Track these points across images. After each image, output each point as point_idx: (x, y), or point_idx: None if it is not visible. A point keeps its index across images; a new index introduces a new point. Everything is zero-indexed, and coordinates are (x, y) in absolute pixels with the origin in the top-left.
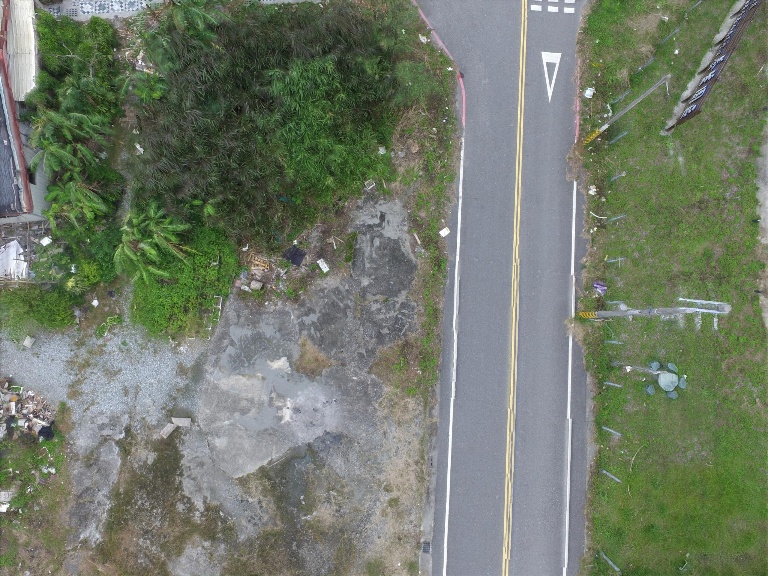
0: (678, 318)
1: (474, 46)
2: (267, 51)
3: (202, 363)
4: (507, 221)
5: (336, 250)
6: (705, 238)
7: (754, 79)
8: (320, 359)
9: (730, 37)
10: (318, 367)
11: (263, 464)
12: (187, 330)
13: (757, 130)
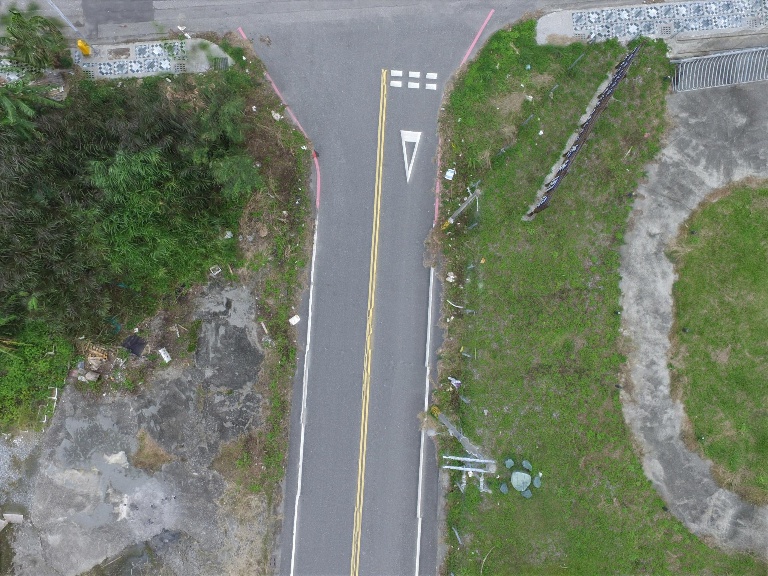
0: (535, 413)
1: (330, 124)
2: (91, 138)
3: (36, 457)
4: (360, 309)
5: (179, 339)
6: (565, 329)
7: (621, 162)
8: (160, 454)
9: (588, 123)
10: (157, 462)
11: (98, 563)
12: (18, 423)
13: (622, 216)
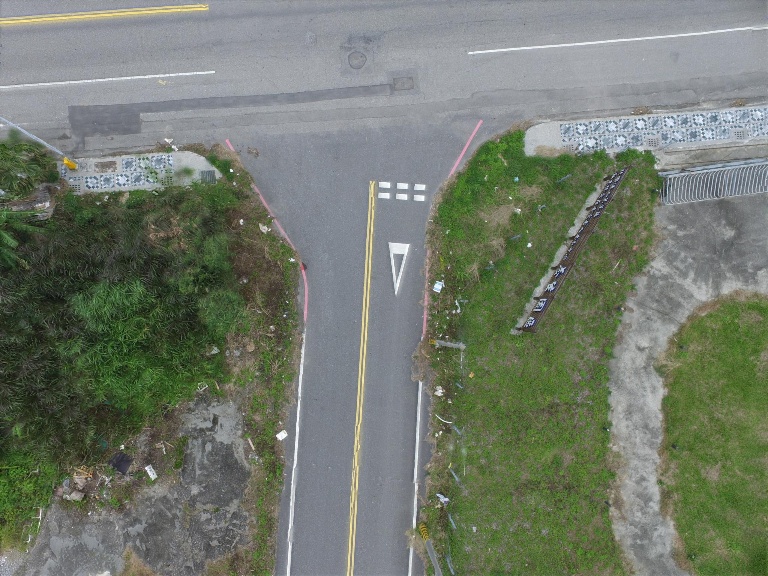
0: (524, 530)
1: (317, 236)
2: (76, 266)
3: None
4: (348, 424)
5: (165, 456)
6: (554, 445)
7: (609, 275)
8: (145, 574)
9: (575, 243)
10: None
11: None
12: (2, 545)
13: (611, 330)
